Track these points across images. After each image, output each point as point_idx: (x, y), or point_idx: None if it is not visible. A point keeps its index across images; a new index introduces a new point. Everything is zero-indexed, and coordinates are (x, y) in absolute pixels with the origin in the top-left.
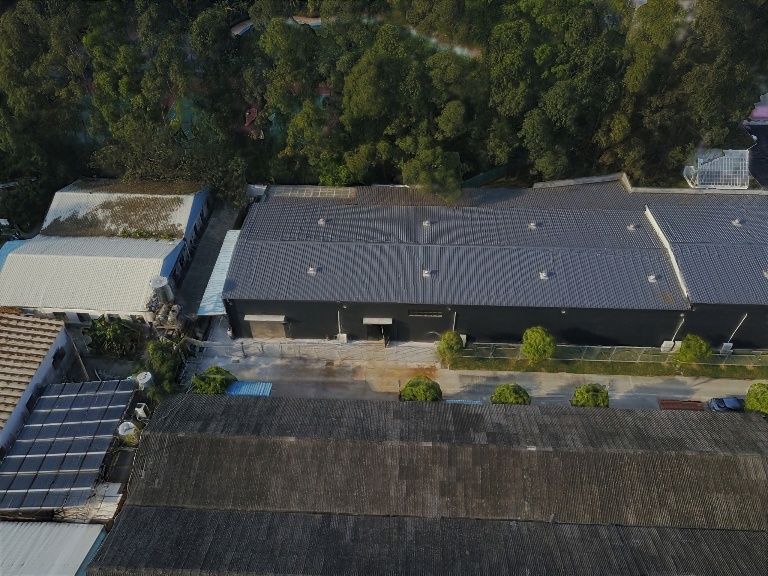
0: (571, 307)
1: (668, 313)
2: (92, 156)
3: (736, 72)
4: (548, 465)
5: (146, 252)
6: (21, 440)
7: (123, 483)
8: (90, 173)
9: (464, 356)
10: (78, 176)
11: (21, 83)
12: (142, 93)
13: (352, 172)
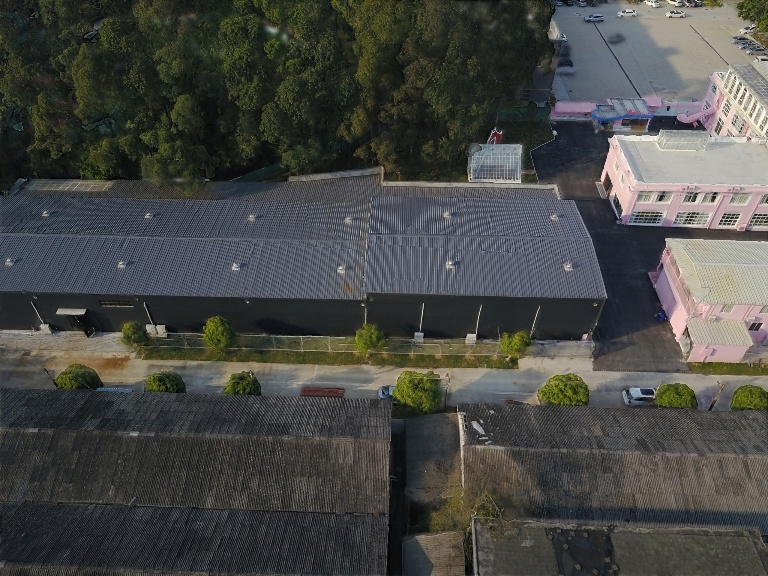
0: (250, 297)
1: (347, 303)
2: None
3: (468, 67)
4: (145, 450)
5: None
6: None
7: None
8: None
9: (161, 346)
10: None
11: None
12: None
13: (111, 166)
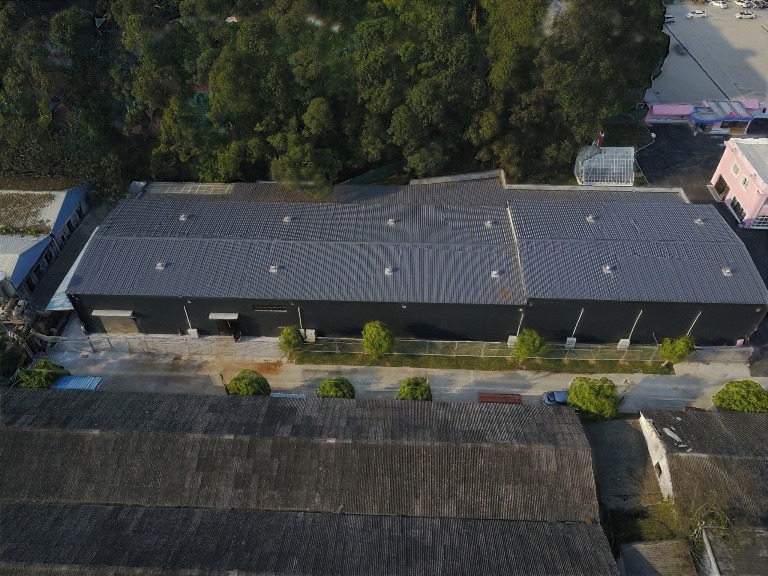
0: (409, 302)
1: (506, 308)
2: None
3: (601, 70)
4: (345, 457)
5: (5, 248)
6: None
7: None
8: None
9: (311, 351)
10: None
11: None
12: (4, 90)
13: None
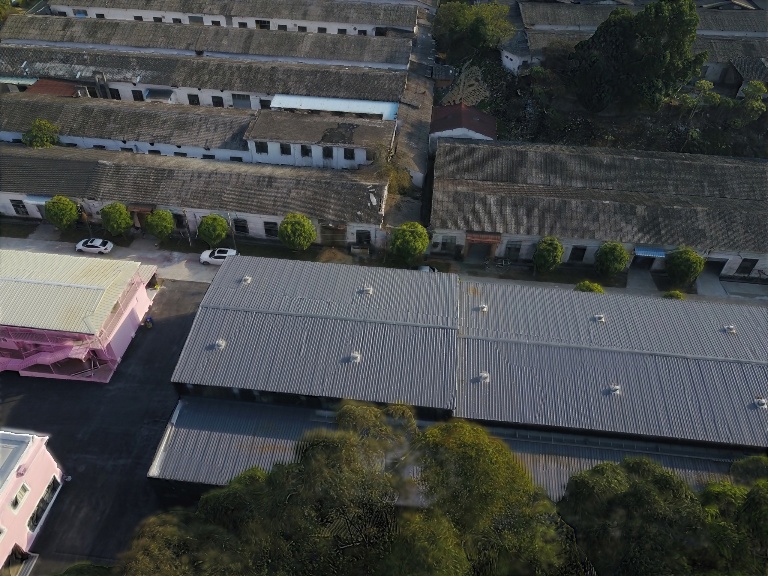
0: None
1: None
2: None
3: None
4: None
5: None
6: None
7: None
8: None
9: None
10: None
11: None
12: None
13: None
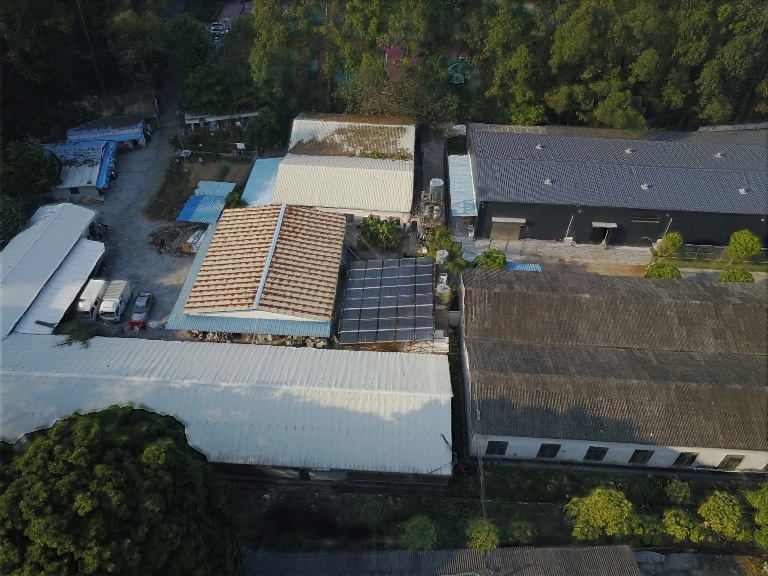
0: None
1: None
2: (336, 87)
3: None
4: None
5: (394, 167)
6: (350, 298)
7: (445, 330)
8: (310, 107)
9: (673, 257)
10: (301, 109)
11: (279, 22)
12: (389, 33)
13: (541, 113)
